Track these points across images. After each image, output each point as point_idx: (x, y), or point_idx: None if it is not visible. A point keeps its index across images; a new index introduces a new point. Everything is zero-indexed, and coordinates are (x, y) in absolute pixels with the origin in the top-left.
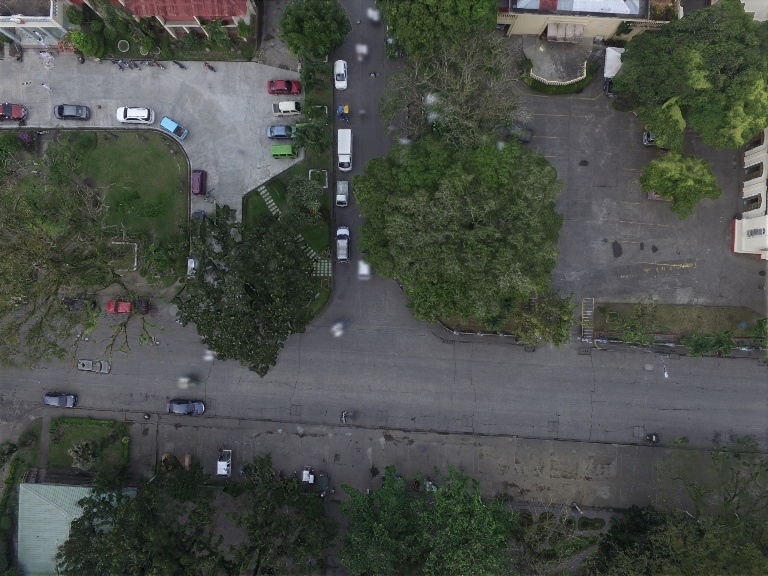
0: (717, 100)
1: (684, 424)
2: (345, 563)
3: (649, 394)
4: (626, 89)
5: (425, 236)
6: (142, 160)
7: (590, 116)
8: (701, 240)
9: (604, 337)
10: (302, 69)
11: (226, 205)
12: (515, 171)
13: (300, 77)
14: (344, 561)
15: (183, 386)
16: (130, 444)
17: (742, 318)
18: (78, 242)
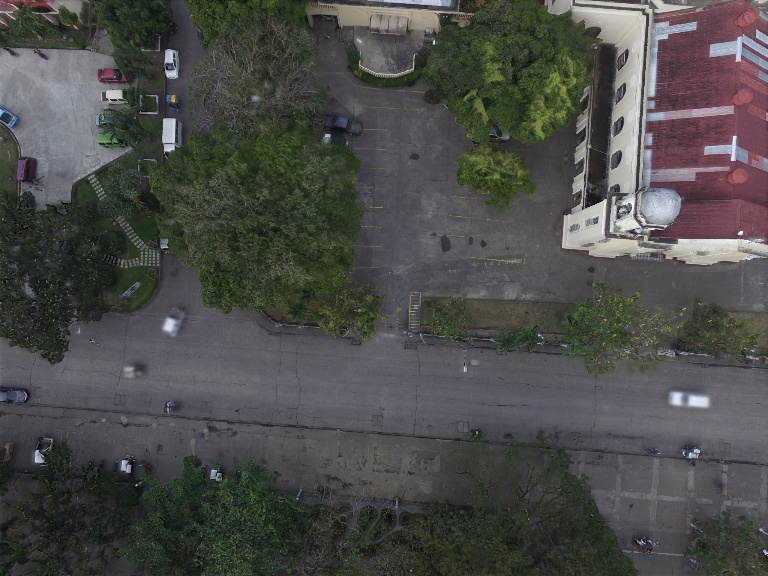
0: (511, 93)
1: (509, 420)
2: (123, 552)
3: (474, 389)
4: (434, 81)
5: (200, 224)
6: None
7: (422, 109)
8: (530, 236)
9: (430, 331)
10: None
11: (27, 191)
12: (293, 160)
13: None
14: (122, 550)
15: (8, 374)
16: None
17: None
18: None
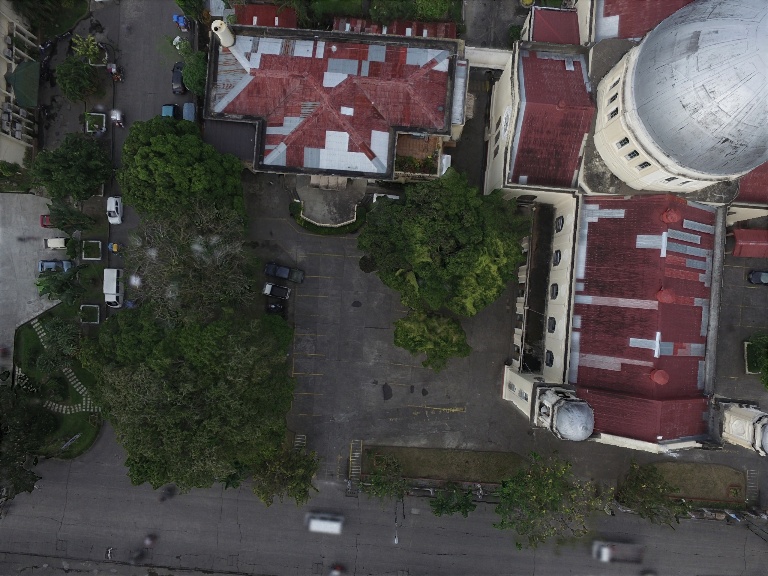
0: (440, 275)
1: (448, 569)
2: None
3: (414, 538)
4: None
5: (124, 416)
6: None
7: None
8: (472, 384)
9: (370, 480)
10: None
11: None
12: (218, 352)
13: None
14: None
15: None
16: None
17: (510, 464)
18: None
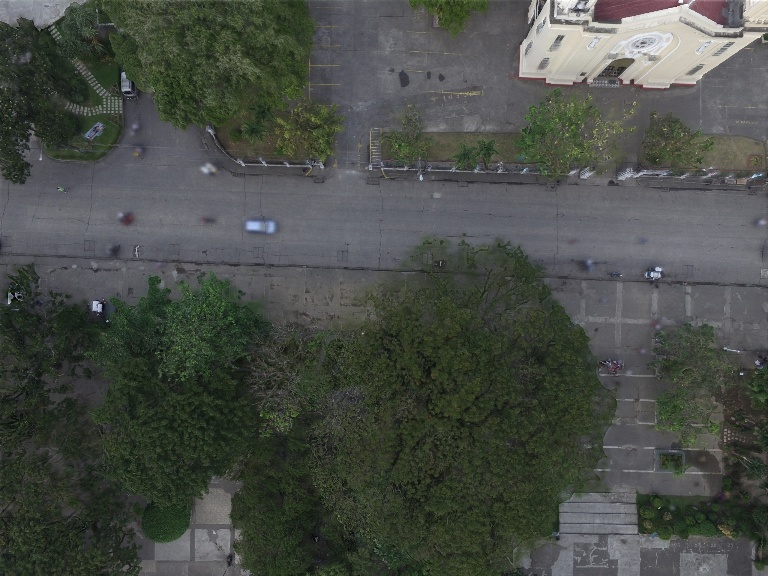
0: None
1: None
2: (89, 355)
3: (437, 221)
4: None
5: (148, 23)
6: None
7: None
8: (488, 67)
9: (391, 166)
10: None
11: None
12: None
13: None
14: (88, 353)
15: None
16: None
17: None
18: None
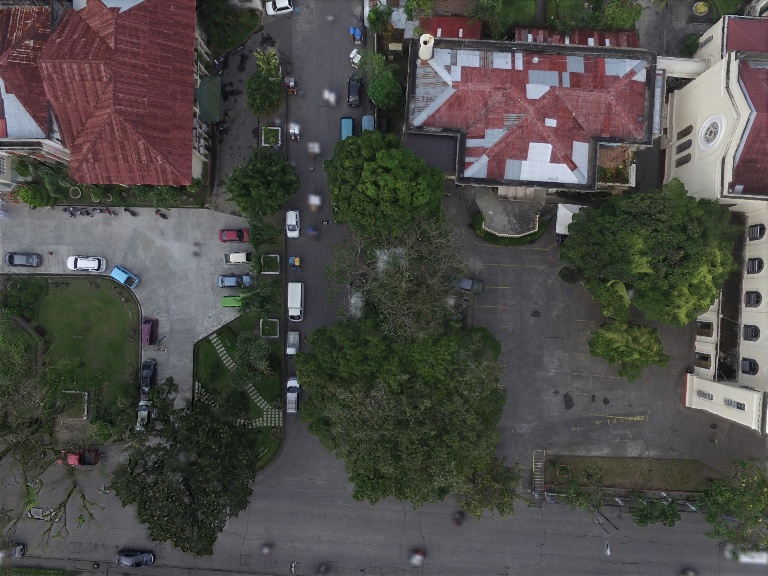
0: (660, 286)
1: None
2: None
3: (599, 547)
4: (572, 261)
5: (361, 433)
6: (93, 307)
7: (543, 266)
8: (653, 392)
9: (554, 490)
10: None
11: (169, 377)
12: (452, 367)
13: None
14: None
15: (133, 535)
16: None
17: (693, 471)
18: None
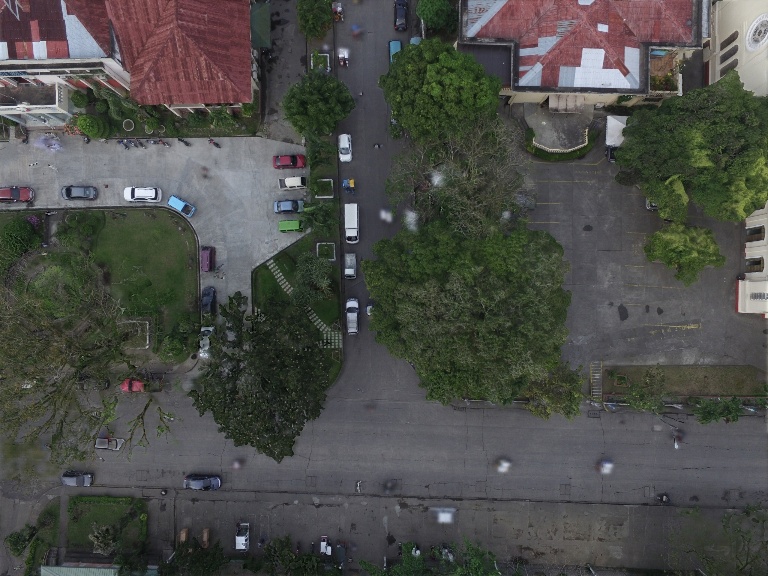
0: (719, 178)
1: (694, 483)
2: None
3: (658, 454)
4: (629, 164)
5: (437, 327)
6: (150, 238)
7: (593, 181)
8: (705, 301)
9: (613, 400)
10: (307, 144)
11: (238, 292)
12: (523, 259)
13: (305, 150)
14: None
15: (199, 461)
16: (148, 520)
17: (748, 376)
18: (90, 322)
